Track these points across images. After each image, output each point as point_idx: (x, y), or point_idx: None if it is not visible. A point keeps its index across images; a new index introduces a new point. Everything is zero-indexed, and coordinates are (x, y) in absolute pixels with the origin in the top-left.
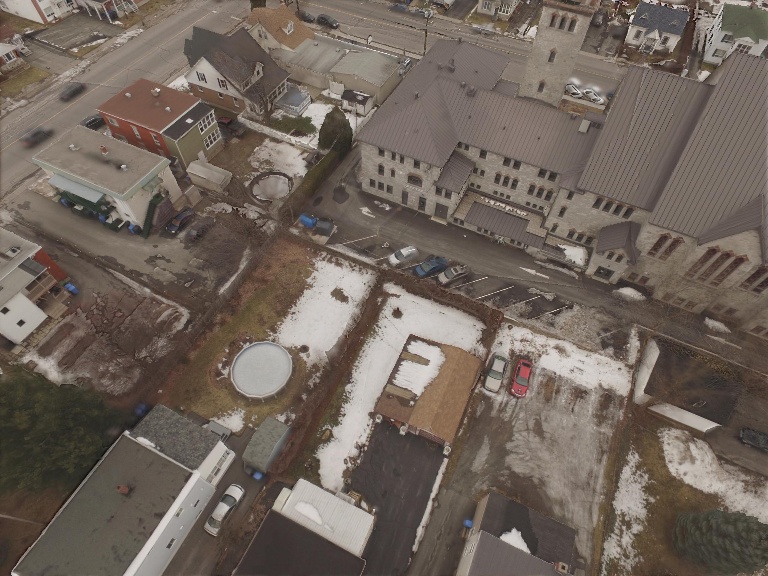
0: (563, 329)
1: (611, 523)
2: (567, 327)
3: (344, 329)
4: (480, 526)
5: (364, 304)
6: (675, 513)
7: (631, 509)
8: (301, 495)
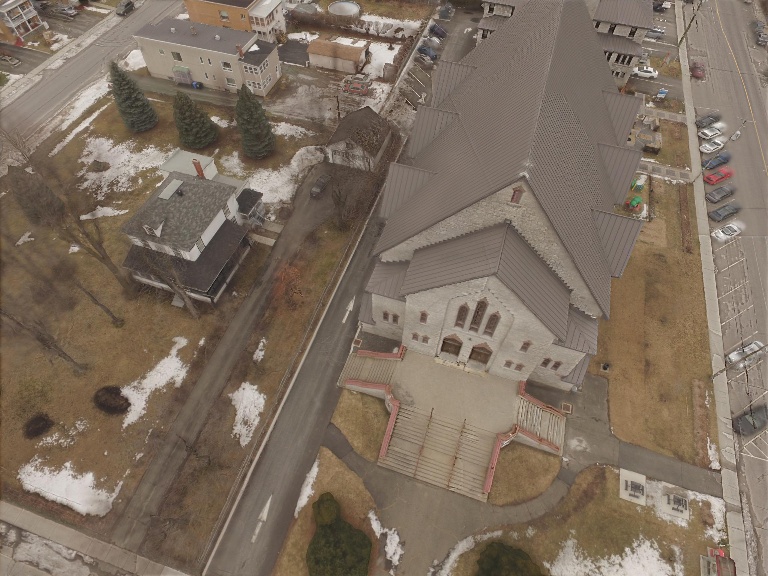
0: (394, 104)
1: (273, 120)
2: (397, 106)
3: (375, 31)
4: (261, 40)
5: (388, 26)
6: (279, 145)
7: (281, 129)
8: (274, 0)
